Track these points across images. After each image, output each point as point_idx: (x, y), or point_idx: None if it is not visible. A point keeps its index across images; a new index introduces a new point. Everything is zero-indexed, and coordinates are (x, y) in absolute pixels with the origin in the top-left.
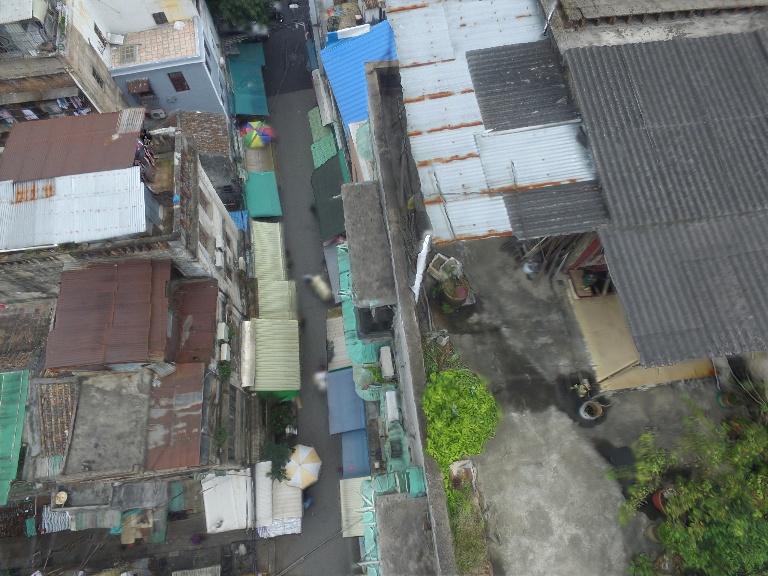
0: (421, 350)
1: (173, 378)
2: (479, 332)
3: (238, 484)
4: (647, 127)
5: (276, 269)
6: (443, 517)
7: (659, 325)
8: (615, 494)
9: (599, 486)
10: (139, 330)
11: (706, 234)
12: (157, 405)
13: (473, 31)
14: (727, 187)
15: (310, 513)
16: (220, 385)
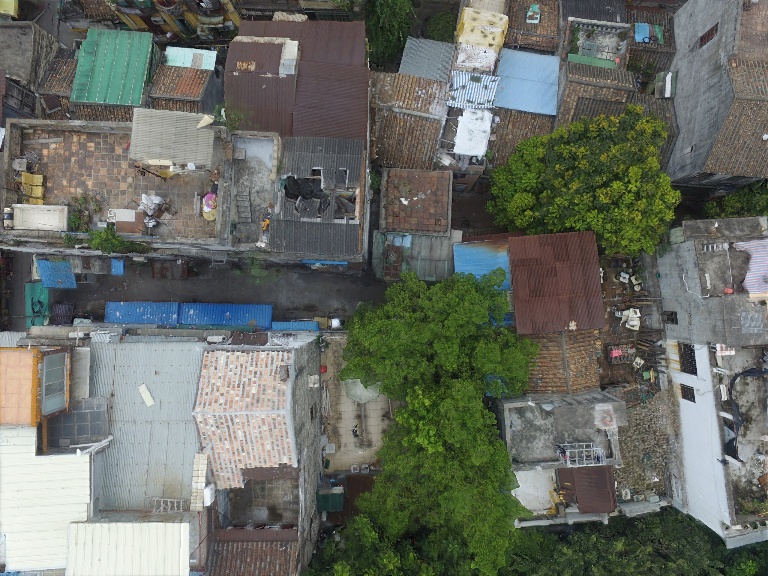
0: None
1: None
2: None
3: None
4: None
5: None
6: None
7: None
8: None
9: None
10: None
11: None
12: None
13: None
14: None
15: None
16: None
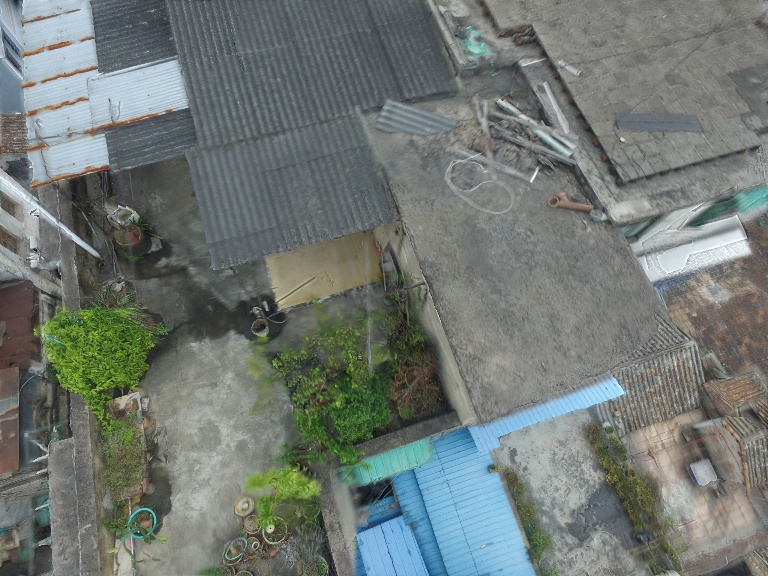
0: (78, 297)
1: None
2: (165, 274)
3: None
4: (238, 53)
5: None
6: (84, 445)
7: (234, 230)
8: (283, 398)
9: (268, 394)
10: None
11: (288, 144)
12: None
13: None
14: (311, 100)
15: None
16: (54, 388)
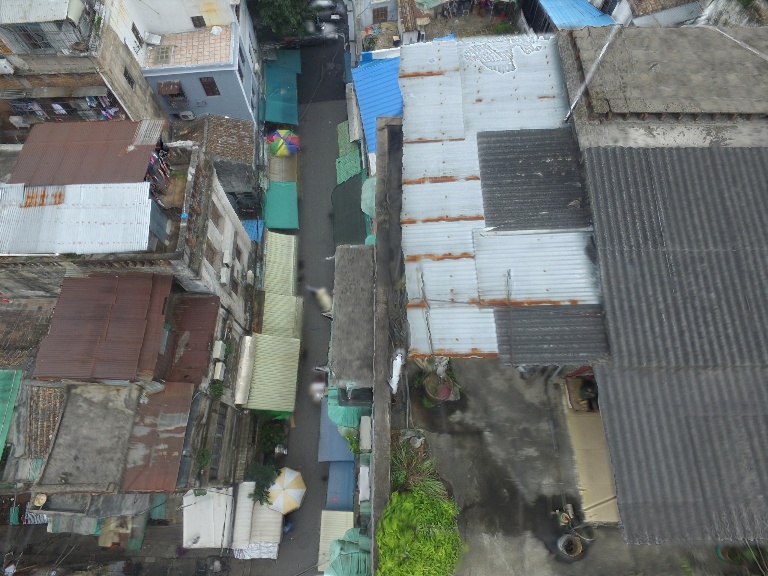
0: (389, 456)
1: (161, 396)
2: (459, 433)
3: (219, 502)
4: (666, 249)
5: (286, 283)
6: None
7: (650, 492)
8: None
9: None
10: (131, 347)
11: (720, 386)
12: (141, 423)
13: (489, 109)
14: (751, 331)
15: (290, 537)
16: (210, 404)
